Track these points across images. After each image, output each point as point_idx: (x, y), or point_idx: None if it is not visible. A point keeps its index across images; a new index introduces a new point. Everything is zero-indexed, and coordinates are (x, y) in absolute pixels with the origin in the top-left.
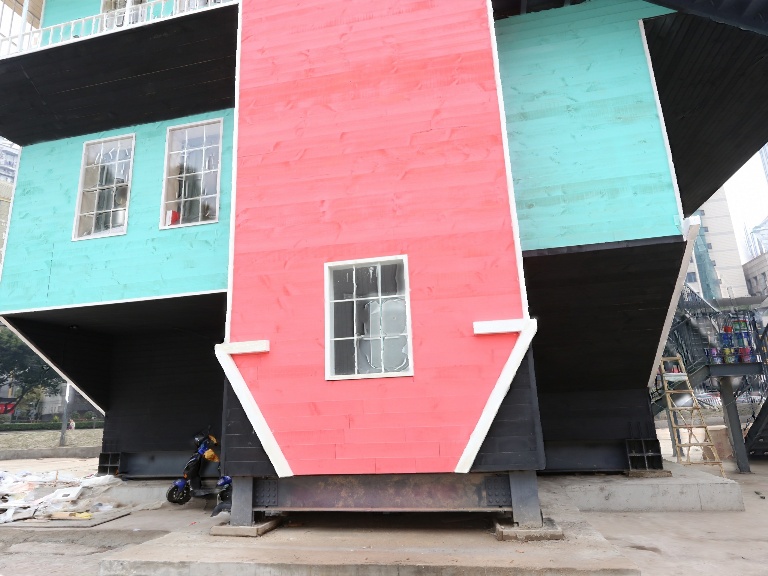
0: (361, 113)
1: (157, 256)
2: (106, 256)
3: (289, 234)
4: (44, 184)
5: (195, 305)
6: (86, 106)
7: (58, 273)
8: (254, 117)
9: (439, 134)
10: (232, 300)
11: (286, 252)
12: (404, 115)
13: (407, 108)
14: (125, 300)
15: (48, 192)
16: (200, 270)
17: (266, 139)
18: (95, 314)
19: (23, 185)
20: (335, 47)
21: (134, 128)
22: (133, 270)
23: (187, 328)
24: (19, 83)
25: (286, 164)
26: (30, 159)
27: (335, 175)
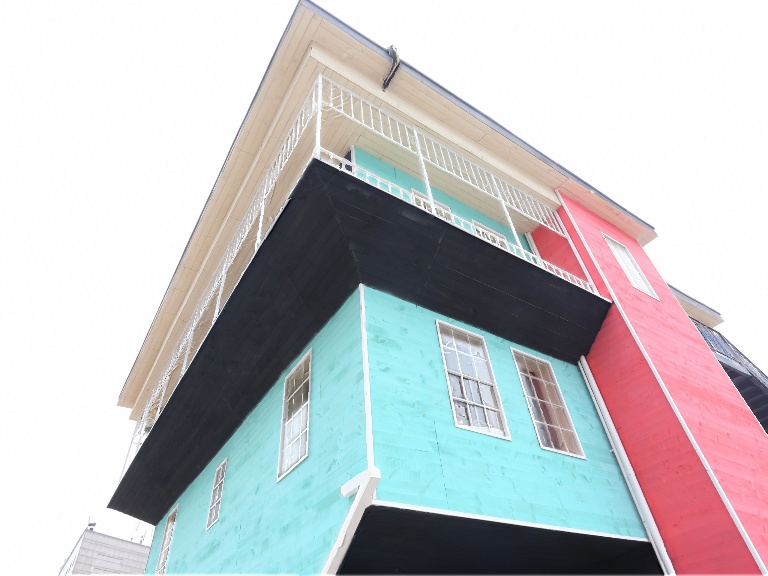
0: (726, 423)
1: (549, 478)
2: (499, 460)
3: (750, 502)
4: (401, 341)
5: (546, 546)
6: (460, 292)
7: (451, 464)
8: (675, 394)
9: (767, 456)
10: (759, 555)
11: (759, 518)
12: (745, 435)
13: (744, 431)
14: (539, 525)
15: (409, 353)
16: (592, 507)
17: (692, 416)
18: (445, 533)
19: (374, 329)
20: (686, 369)
21: (481, 331)
22: (533, 487)
23: (415, 573)
24: (427, 240)
25: (714, 442)
26: (376, 304)
27: (743, 463)
